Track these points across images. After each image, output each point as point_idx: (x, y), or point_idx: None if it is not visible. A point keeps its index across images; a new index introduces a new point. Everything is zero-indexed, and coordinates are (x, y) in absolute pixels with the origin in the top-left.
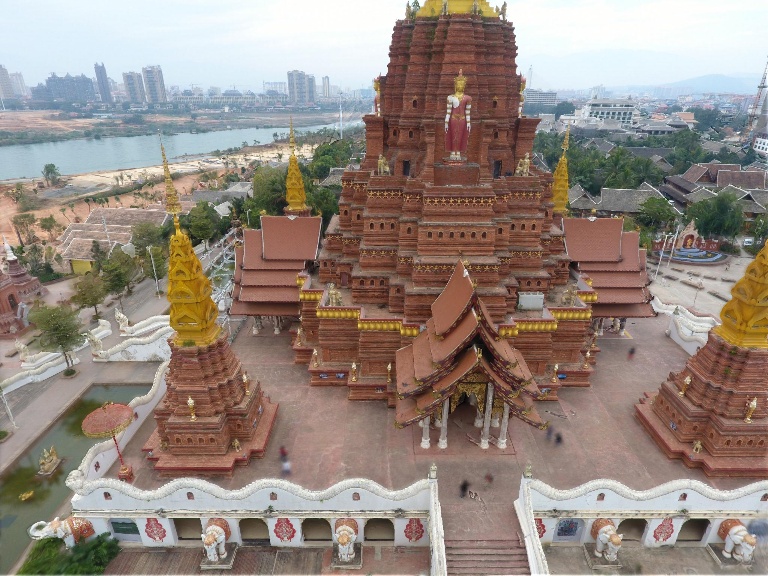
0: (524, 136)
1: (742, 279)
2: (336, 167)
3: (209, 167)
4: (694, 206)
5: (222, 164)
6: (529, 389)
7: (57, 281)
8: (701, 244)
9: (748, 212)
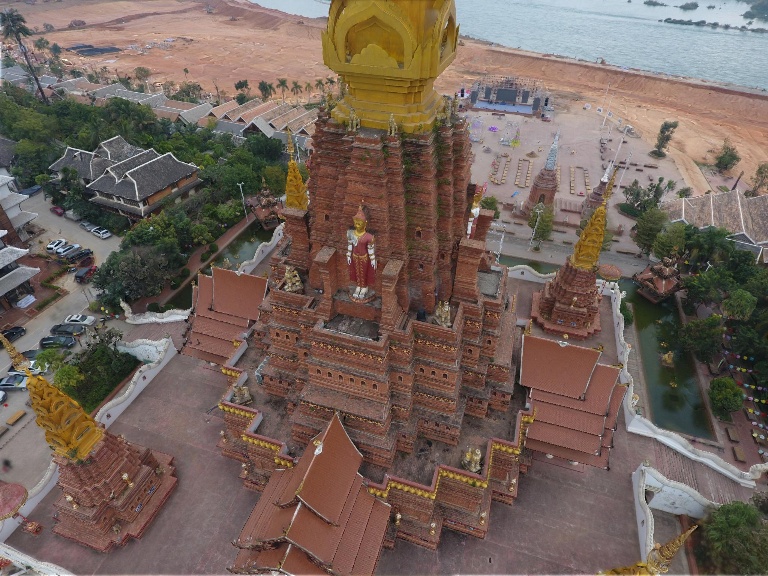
0: None
1: (73, 408)
2: None
3: None
4: None
5: None
6: (192, 337)
7: (631, 217)
8: None
9: None
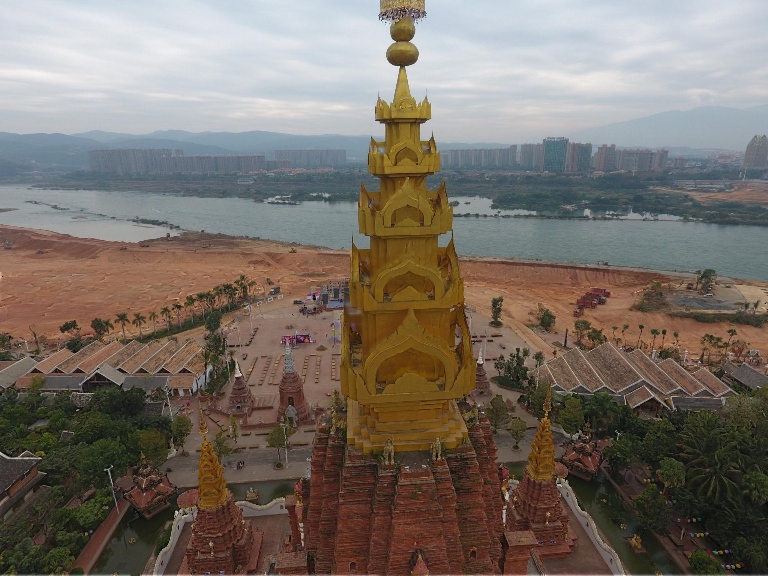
0: None
1: None
2: None
3: None
4: None
5: None
6: None
7: (511, 389)
8: None
9: None
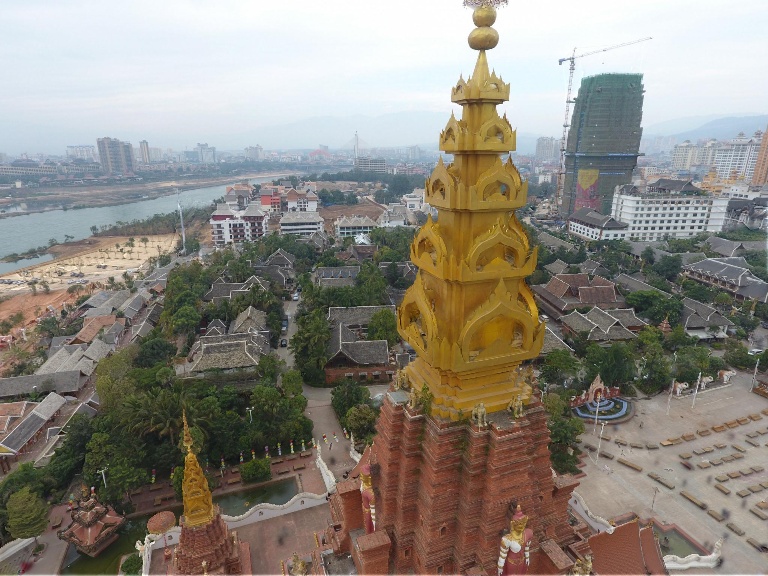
0: (560, 501)
1: None
2: (209, 343)
3: (6, 293)
4: (589, 350)
5: (25, 285)
6: None
7: None
8: (607, 393)
9: (621, 338)
